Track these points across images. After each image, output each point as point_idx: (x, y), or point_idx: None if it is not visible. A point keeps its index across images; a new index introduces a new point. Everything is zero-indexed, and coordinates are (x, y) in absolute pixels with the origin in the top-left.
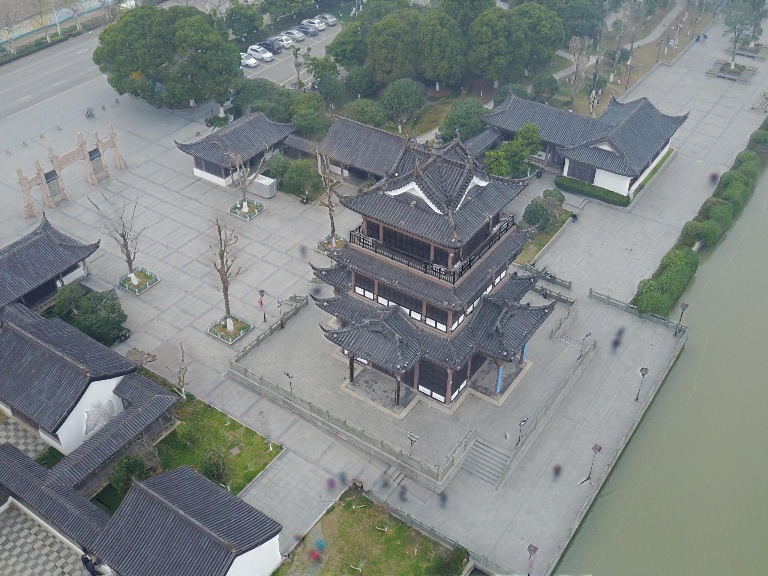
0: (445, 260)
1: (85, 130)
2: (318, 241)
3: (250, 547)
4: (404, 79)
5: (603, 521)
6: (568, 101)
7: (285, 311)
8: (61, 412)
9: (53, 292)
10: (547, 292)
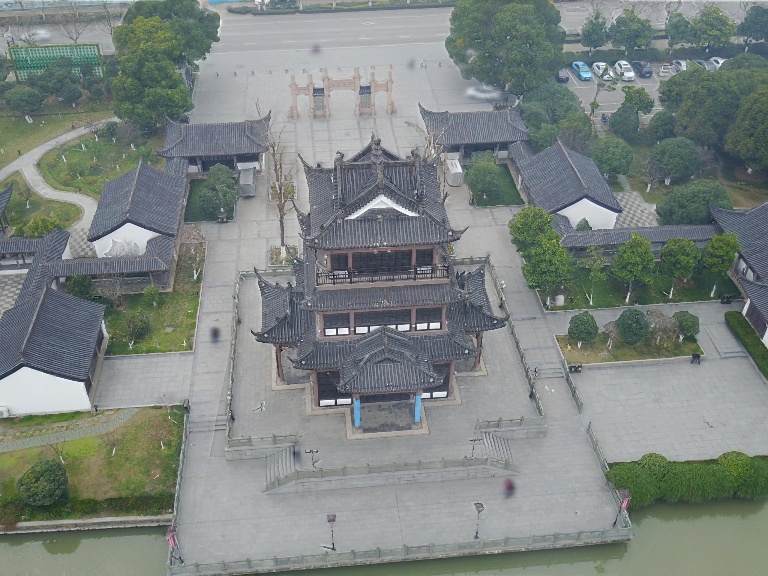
0: None
1: (406, 75)
2: None
3: (43, 369)
4: (682, 138)
5: None
6: None
7: None
8: (101, 231)
9: (232, 170)
10: (534, 391)
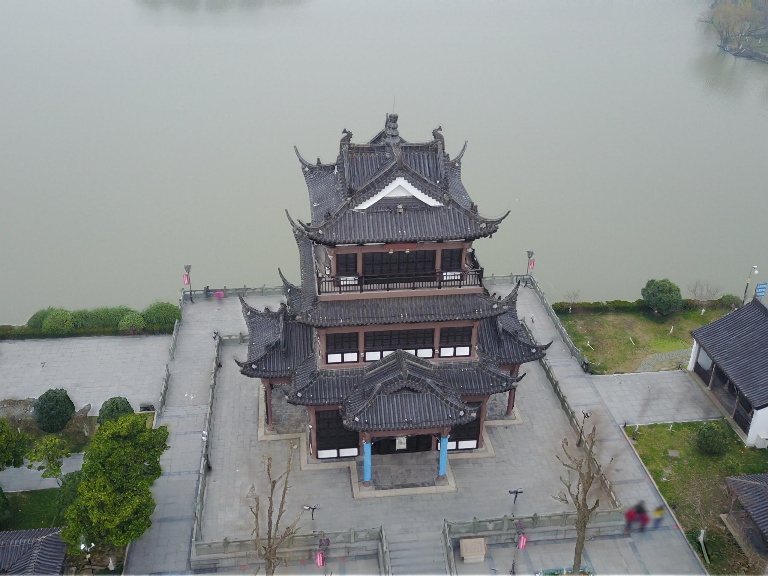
0: None
1: None
2: None
3: None
4: None
5: None
6: None
7: (484, 545)
8: None
9: None
10: (217, 360)
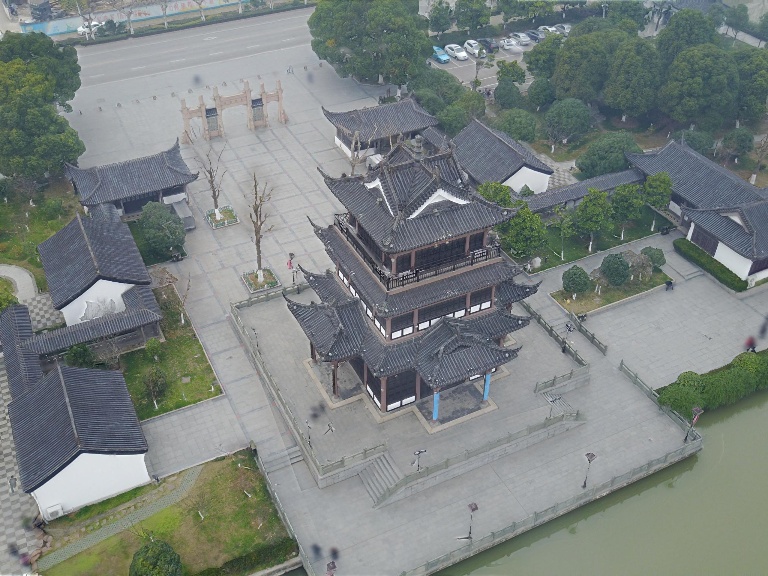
0: (390, 264)
1: None
2: None
3: (102, 451)
4: (573, 99)
5: None
6: (763, 165)
7: None
8: (69, 295)
9: None
10: (566, 346)
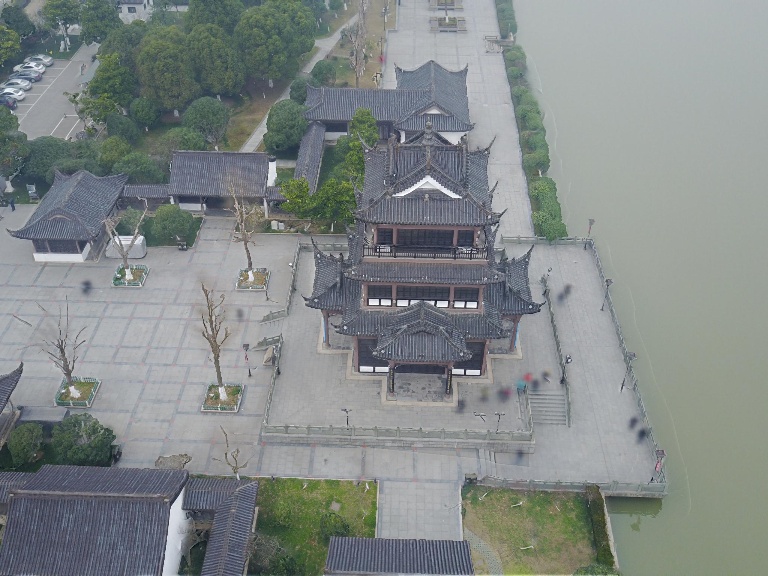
0: (470, 240)
1: None
2: (232, 281)
3: None
4: (204, 98)
5: (651, 413)
6: (346, 83)
7: (267, 357)
8: (157, 555)
9: None
10: None
